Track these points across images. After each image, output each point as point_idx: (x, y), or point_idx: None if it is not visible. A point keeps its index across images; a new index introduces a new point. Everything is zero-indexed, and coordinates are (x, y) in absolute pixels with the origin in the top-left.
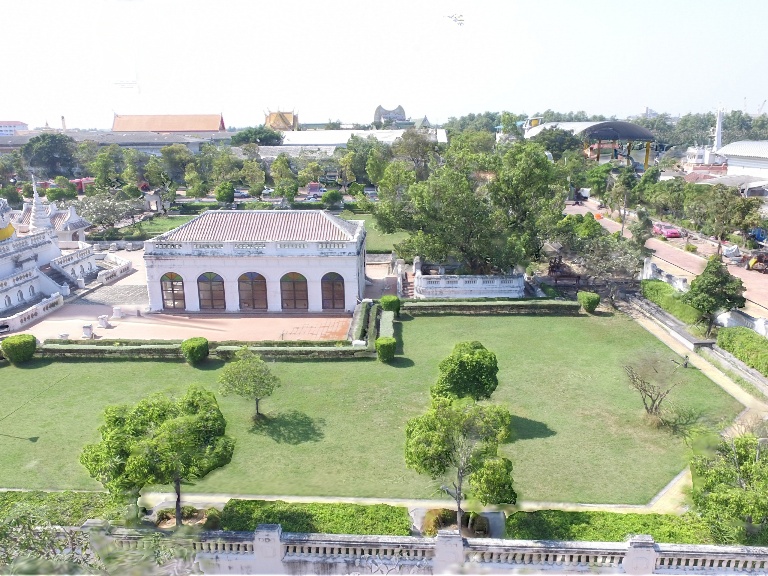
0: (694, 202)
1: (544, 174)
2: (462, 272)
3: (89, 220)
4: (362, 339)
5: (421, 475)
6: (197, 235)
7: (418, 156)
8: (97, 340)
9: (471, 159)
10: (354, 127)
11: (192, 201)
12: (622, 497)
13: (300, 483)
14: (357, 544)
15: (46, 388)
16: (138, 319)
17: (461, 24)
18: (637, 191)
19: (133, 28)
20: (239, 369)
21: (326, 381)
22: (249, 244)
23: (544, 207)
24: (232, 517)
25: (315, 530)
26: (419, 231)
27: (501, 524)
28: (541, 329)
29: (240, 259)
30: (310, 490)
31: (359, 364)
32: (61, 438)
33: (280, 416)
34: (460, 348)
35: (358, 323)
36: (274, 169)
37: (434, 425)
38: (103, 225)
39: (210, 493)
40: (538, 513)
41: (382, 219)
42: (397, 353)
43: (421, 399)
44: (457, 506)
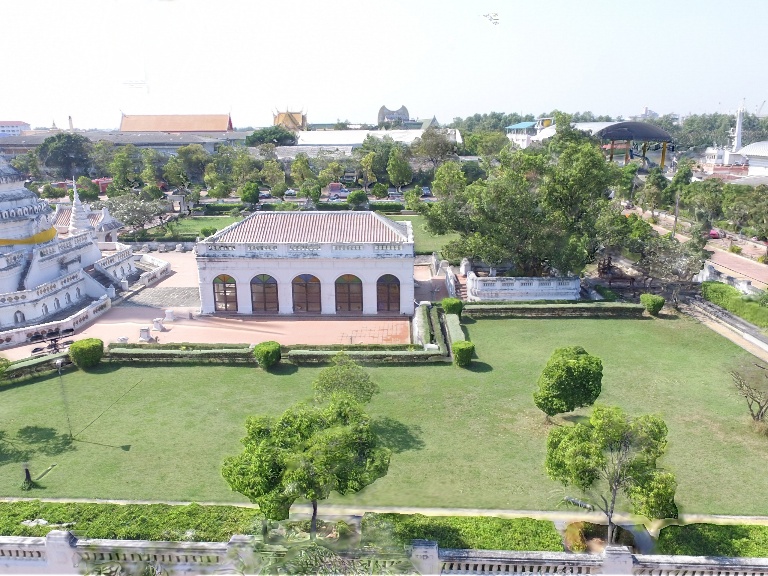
0: (734, 203)
1: (601, 175)
2: (516, 274)
3: (121, 221)
4: (431, 343)
5: (539, 485)
6: (248, 236)
7: (437, 156)
8: (162, 344)
9: (528, 159)
10: (363, 127)
11: (216, 202)
12: (755, 508)
13: (417, 494)
14: (520, 561)
15: (123, 394)
16: (191, 322)
17: (496, 23)
18: (669, 192)
19: (142, 28)
20: (337, 375)
21: (408, 386)
22: (304, 246)
23: (603, 208)
24: (374, 532)
25: (466, 545)
26: (476, 232)
27: (646, 538)
28: (610, 332)
29: (295, 261)
30: (430, 501)
31: (436, 369)
32: (154, 446)
33: (373, 423)
34: (562, 353)
35: (424, 326)
36: (294, 169)
37: (587, 436)
38: (133, 226)
39: (327, 504)
40: (692, 527)
41: (434, 220)
42: (471, 357)
43: (512, 405)
44: (587, 518)
